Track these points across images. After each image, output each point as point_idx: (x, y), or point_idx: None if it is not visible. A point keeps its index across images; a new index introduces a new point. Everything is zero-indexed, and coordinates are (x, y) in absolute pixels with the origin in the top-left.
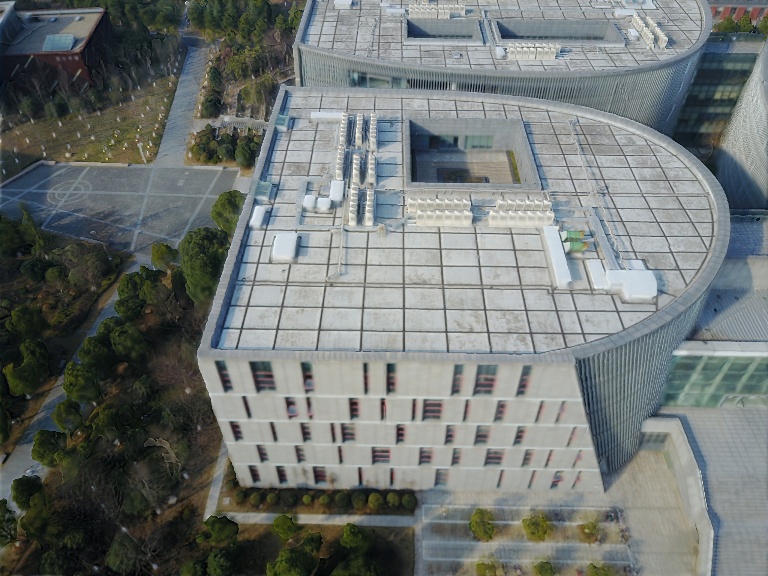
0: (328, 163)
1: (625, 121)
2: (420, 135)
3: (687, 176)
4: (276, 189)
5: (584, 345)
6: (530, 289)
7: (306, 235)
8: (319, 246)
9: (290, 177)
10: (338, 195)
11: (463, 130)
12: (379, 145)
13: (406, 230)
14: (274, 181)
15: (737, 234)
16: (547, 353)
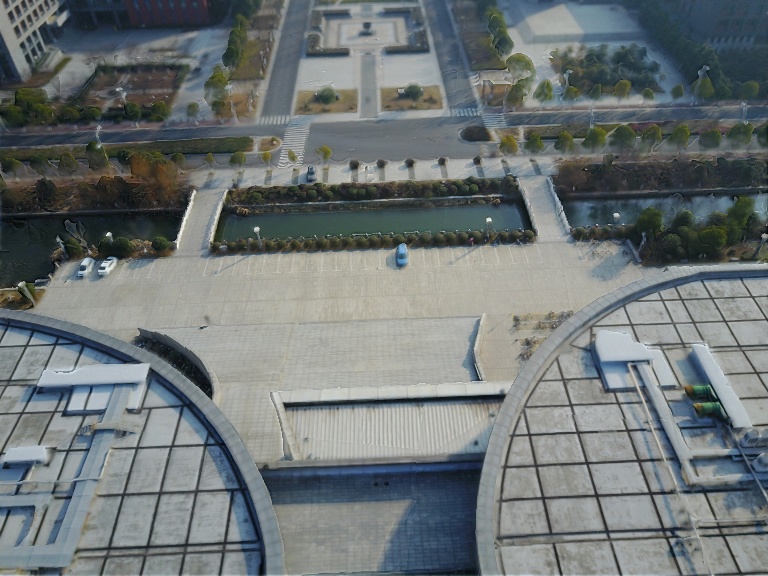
0: None
1: None
2: None
3: None
4: None
5: (663, 280)
6: (731, 346)
7: None
8: None
9: None
10: None
11: None
12: None
13: None
14: None
15: (427, 545)
16: (694, 272)
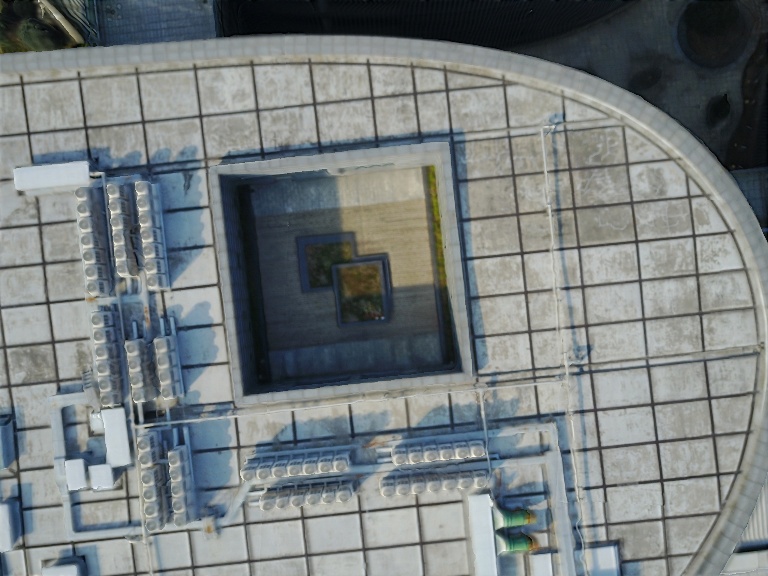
0: (86, 340)
1: (658, 125)
2: (250, 178)
3: (738, 296)
4: (12, 429)
5: None
6: None
7: (91, 552)
8: (117, 574)
9: (27, 390)
10: (120, 454)
11: (332, 166)
12: (171, 267)
13: (248, 518)
14: (2, 407)
15: None
16: None
